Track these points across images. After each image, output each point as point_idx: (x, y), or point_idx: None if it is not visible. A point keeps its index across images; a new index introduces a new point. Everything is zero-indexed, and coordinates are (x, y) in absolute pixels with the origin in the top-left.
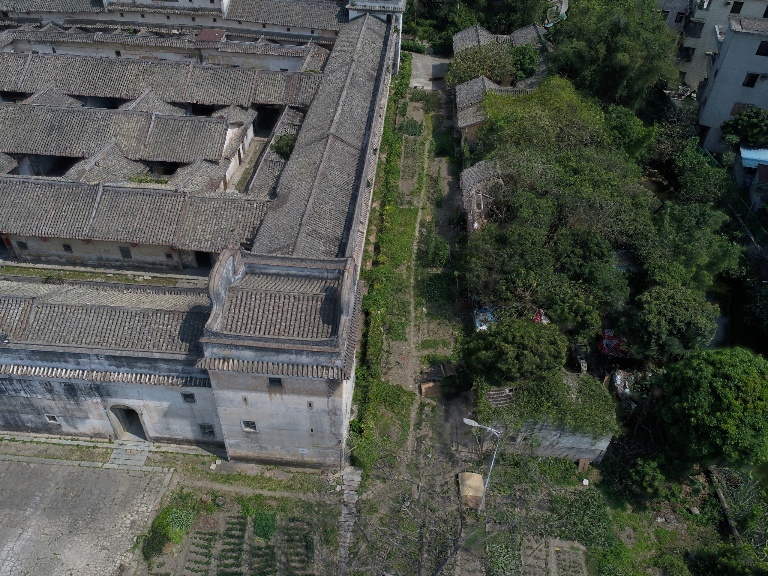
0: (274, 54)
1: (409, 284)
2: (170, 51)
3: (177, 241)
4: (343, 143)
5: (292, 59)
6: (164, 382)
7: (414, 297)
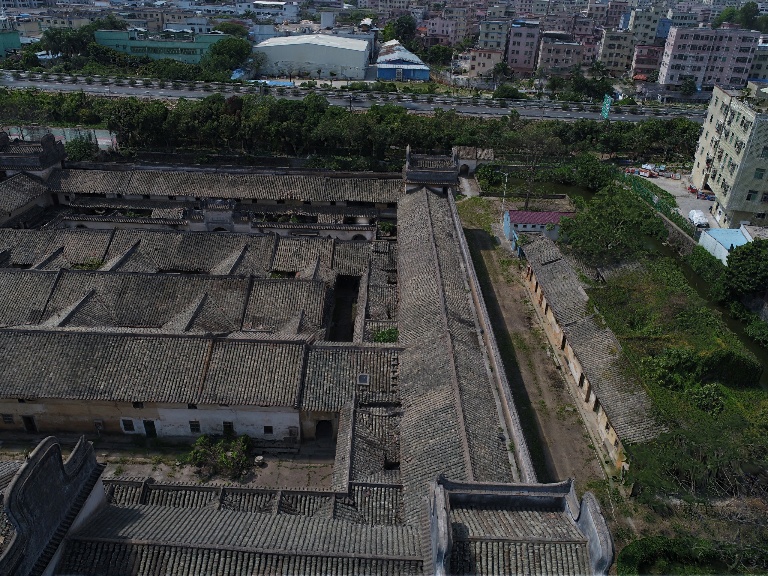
0: None
1: None
2: None
3: None
4: None
5: None
6: None
7: None
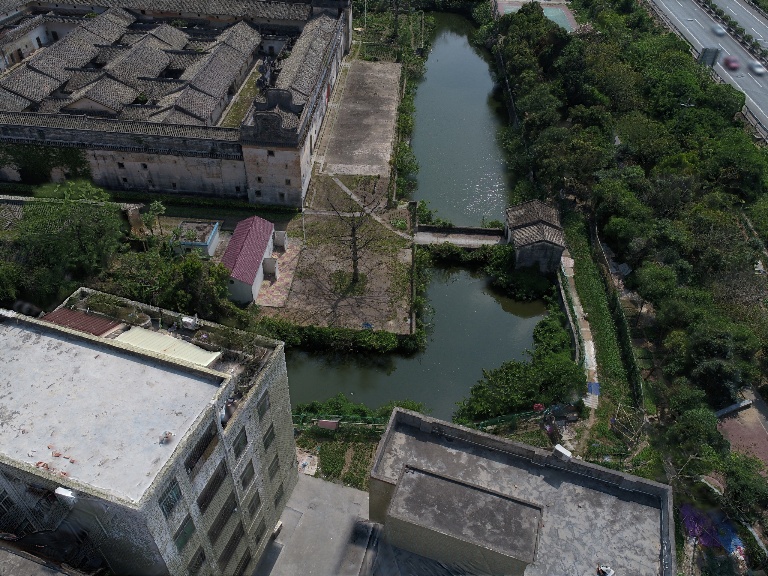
0: (35, 27)
1: None
2: None
3: None
4: None
5: (38, 28)
6: (344, 25)
7: None
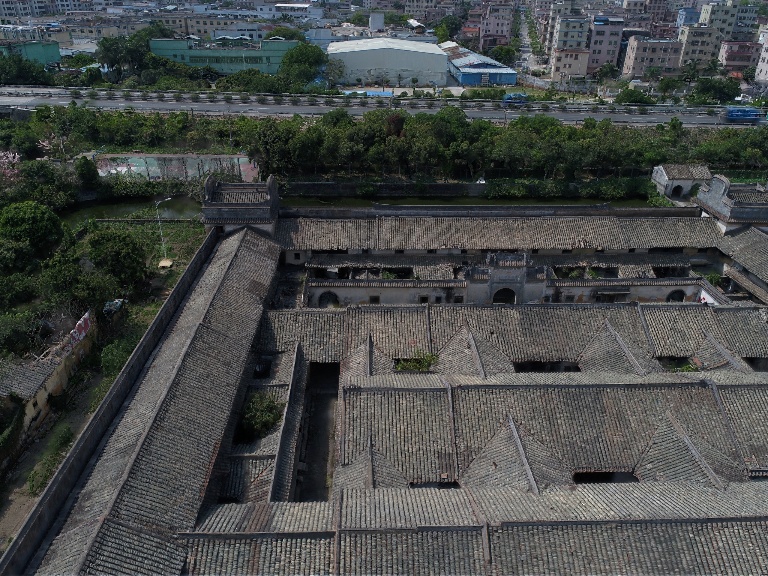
0: None
1: None
2: None
3: None
4: None
5: None
6: None
7: None
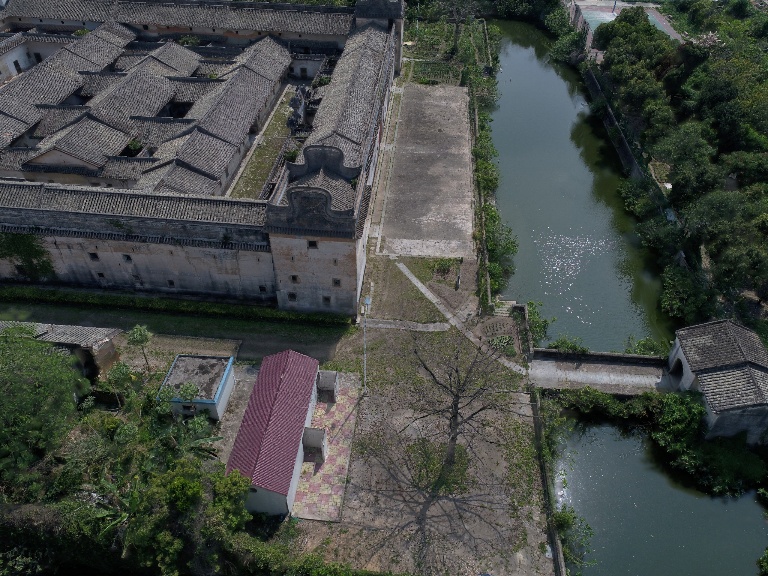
0: (11, 49)
1: None
2: None
3: None
4: None
5: (16, 49)
6: None
7: None
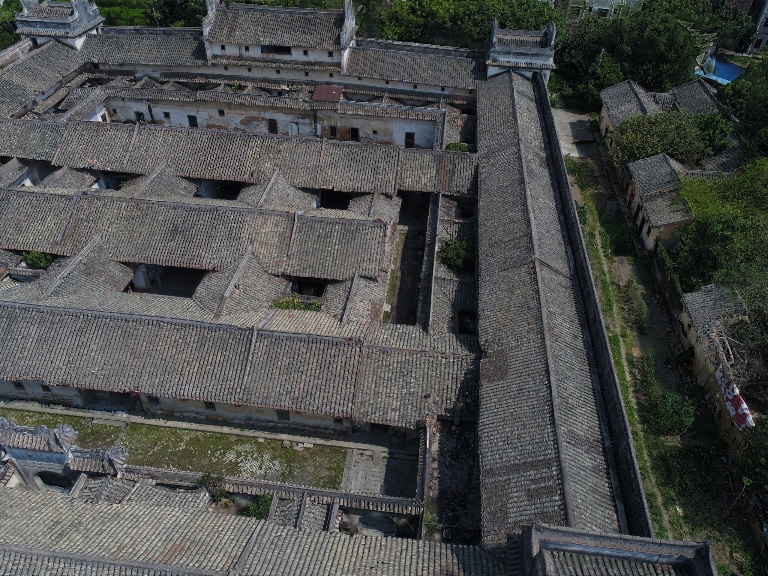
0: (402, 117)
1: (645, 463)
2: (281, 111)
3: (356, 410)
4: (550, 270)
5: (421, 122)
6: None
7: (658, 487)
